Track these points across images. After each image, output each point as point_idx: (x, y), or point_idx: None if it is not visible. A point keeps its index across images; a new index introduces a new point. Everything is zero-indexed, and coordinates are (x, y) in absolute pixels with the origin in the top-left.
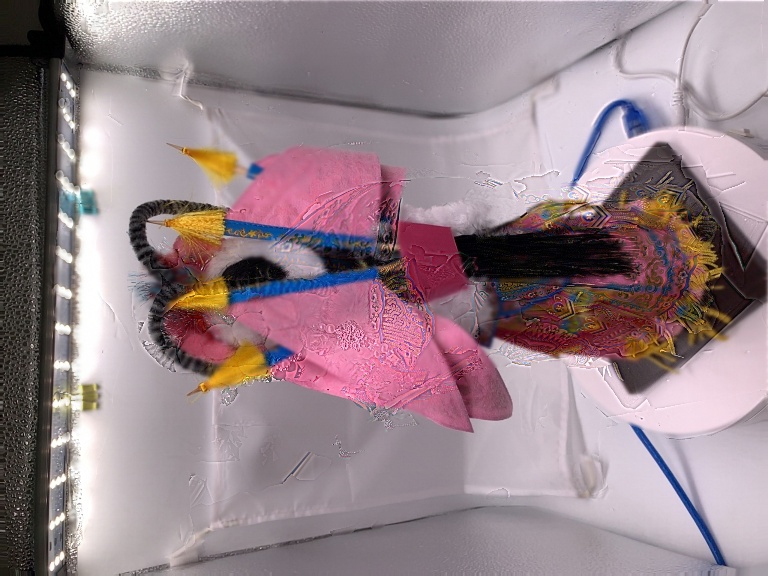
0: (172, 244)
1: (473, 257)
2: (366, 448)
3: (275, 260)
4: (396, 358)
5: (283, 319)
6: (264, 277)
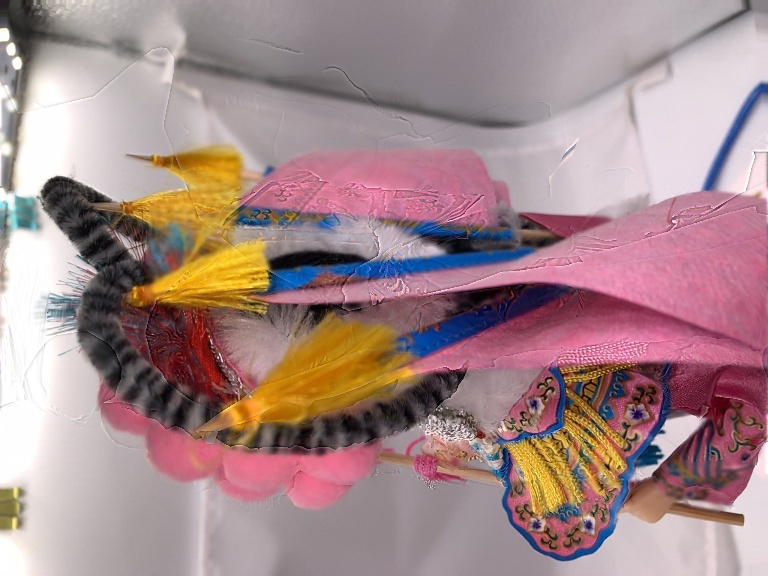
0: (100, 384)
1: (759, 388)
2: (380, 476)
3: (384, 393)
4: (500, 463)
5: (340, 484)
6: (339, 425)
